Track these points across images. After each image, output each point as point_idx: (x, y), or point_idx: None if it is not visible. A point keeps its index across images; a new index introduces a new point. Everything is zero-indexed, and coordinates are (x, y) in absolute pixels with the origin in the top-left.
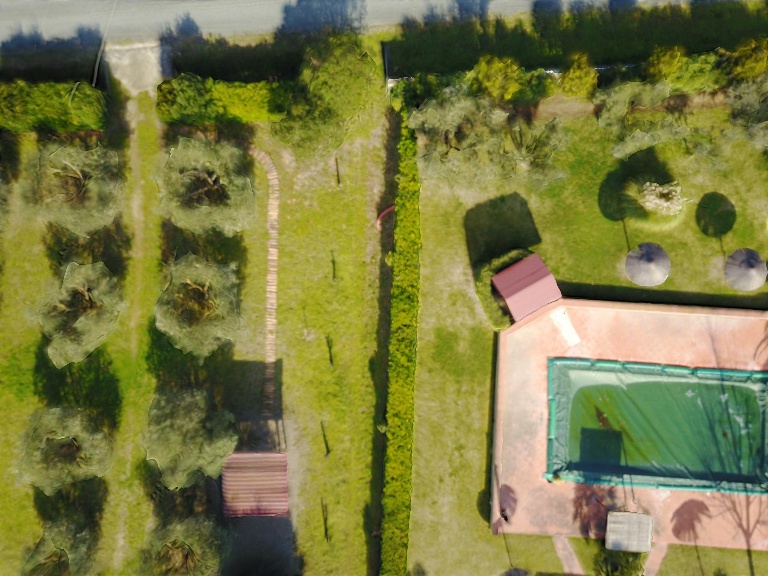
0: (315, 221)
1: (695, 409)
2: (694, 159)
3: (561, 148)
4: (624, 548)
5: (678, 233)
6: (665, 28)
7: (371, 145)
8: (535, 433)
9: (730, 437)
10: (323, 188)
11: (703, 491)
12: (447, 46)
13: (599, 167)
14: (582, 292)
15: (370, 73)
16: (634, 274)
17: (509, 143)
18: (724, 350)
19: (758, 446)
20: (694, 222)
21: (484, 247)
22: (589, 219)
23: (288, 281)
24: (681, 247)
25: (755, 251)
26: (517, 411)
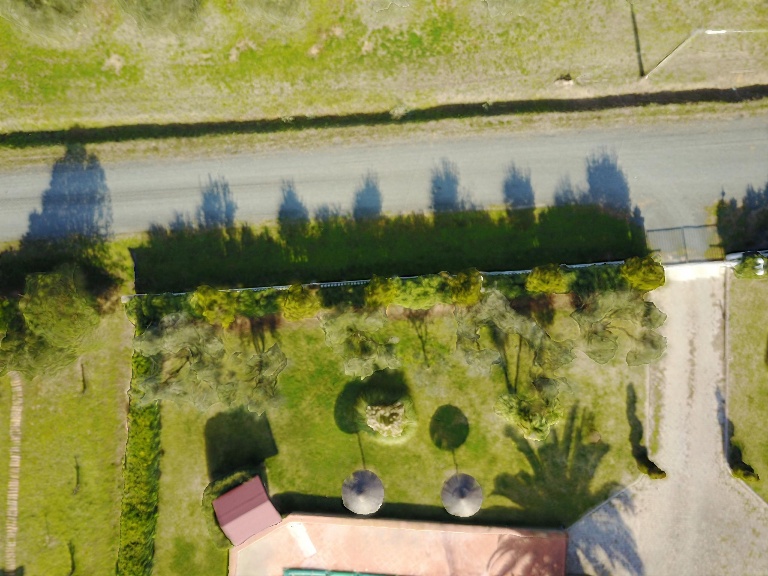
0: (59, 427)
1: None
2: (431, 371)
3: (301, 358)
4: None
5: (412, 446)
6: (408, 237)
7: (122, 347)
8: None
9: None
10: (68, 394)
11: None
12: (193, 253)
13: (337, 378)
14: (316, 505)
15: (77, 311)
16: (348, 503)
17: (251, 352)
18: (458, 561)
19: None
20: (428, 435)
21: (222, 457)
22: (325, 431)
23: (30, 488)
24: (414, 460)
25: (471, 477)
26: None
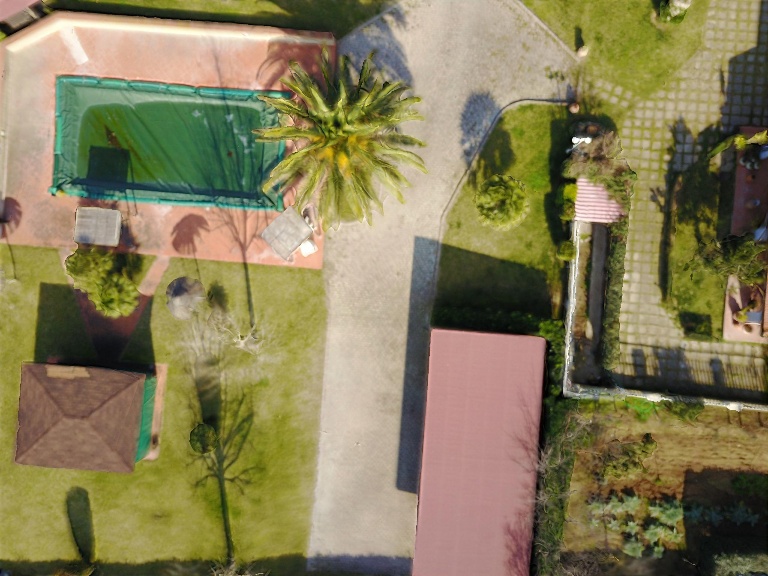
0: None
1: (202, 129)
2: None
3: None
4: (91, 241)
5: None
6: None
7: None
8: (42, 149)
9: (234, 157)
10: None
11: (203, 206)
12: None
13: None
14: (86, 10)
15: None
16: None
17: None
18: (227, 70)
19: (259, 164)
20: None
21: None
22: None
23: None
24: None
25: None
26: (25, 127)
